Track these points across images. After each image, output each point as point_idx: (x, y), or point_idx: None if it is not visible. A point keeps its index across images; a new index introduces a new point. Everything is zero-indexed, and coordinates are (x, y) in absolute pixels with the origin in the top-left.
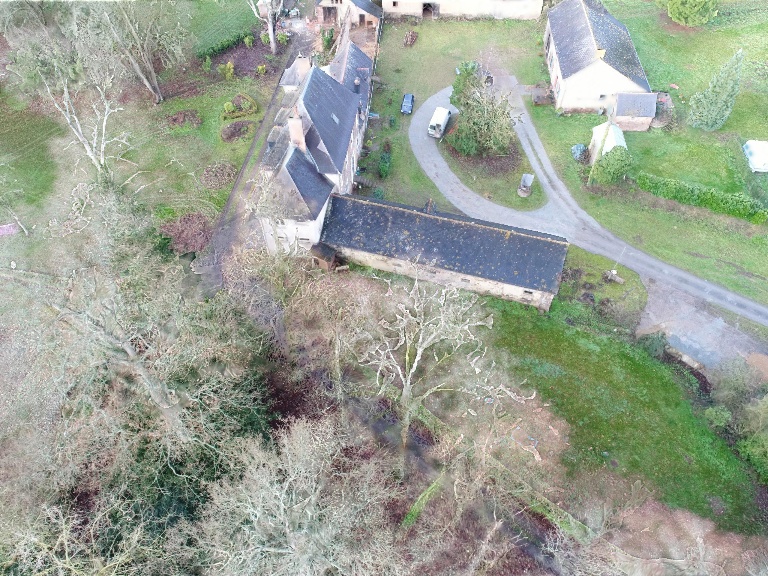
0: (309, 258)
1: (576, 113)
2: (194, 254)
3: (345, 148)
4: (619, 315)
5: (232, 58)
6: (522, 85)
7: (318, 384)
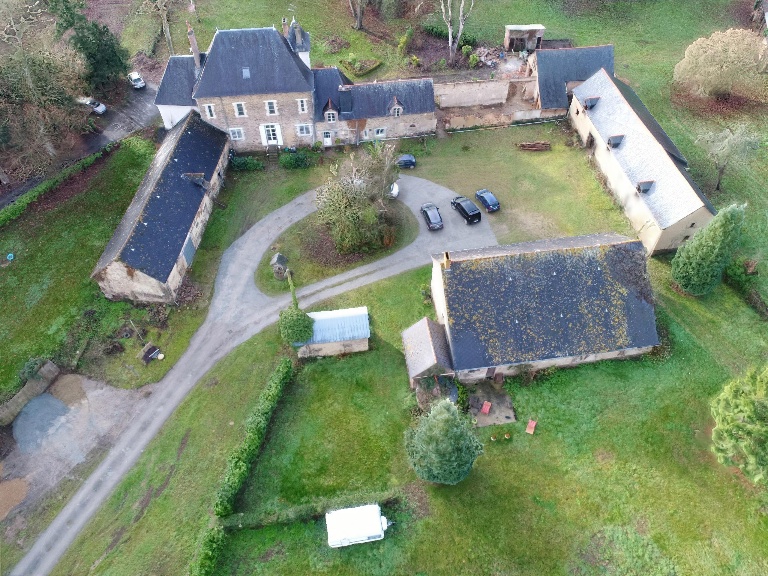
0: None
1: None
2: (117, 59)
3: (226, 94)
4: (92, 353)
5: (433, 44)
6: None
7: None
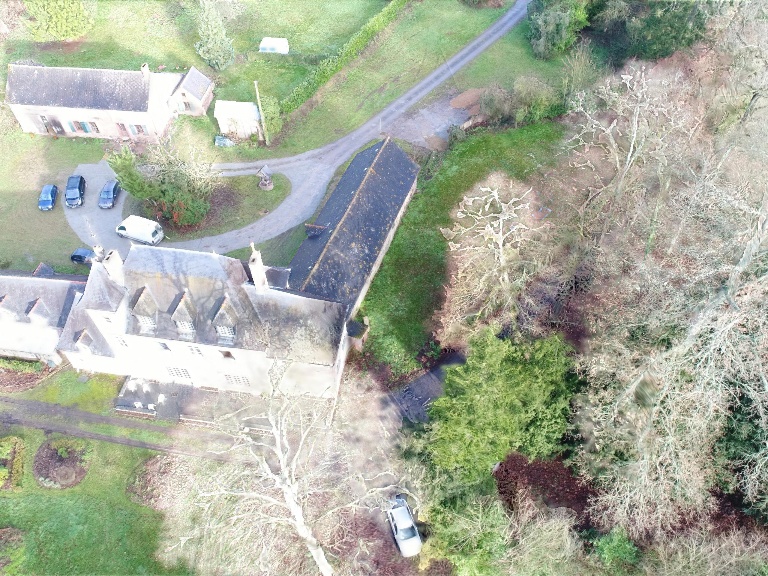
0: (348, 355)
1: (167, 133)
2: None
3: None
4: (422, 152)
5: None
6: (100, 161)
7: (601, 260)
